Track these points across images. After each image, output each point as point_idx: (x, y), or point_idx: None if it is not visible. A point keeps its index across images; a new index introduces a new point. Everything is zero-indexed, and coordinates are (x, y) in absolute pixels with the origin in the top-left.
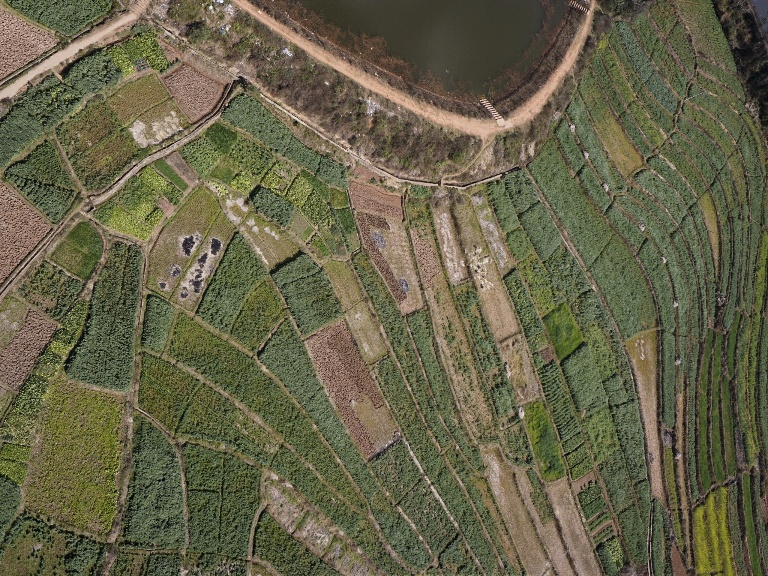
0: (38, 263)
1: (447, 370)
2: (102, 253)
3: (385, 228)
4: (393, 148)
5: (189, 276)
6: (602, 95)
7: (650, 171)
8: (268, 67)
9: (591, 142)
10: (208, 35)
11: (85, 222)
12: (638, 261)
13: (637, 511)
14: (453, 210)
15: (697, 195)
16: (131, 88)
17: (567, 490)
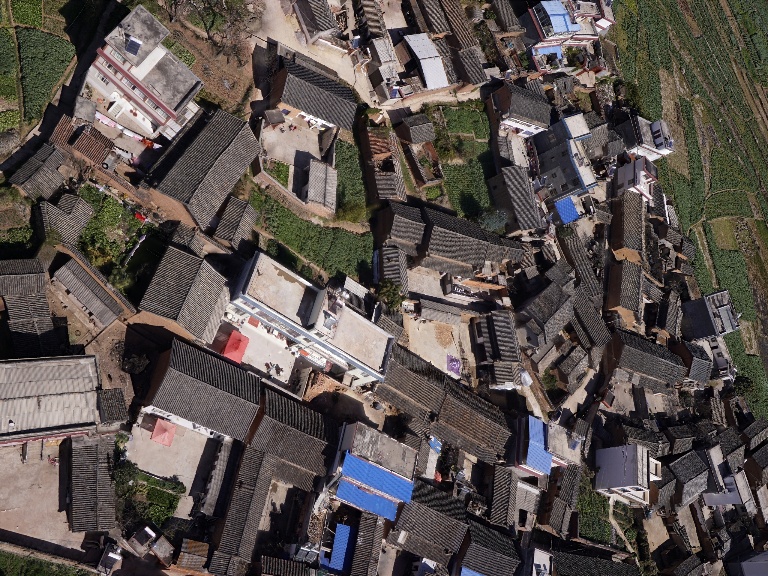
0: None
1: (712, 17)
2: None
3: None
4: None
5: None
6: None
7: None
8: None
9: None
10: None
11: None
12: None
13: None
14: None
15: None
16: None
17: (761, 91)
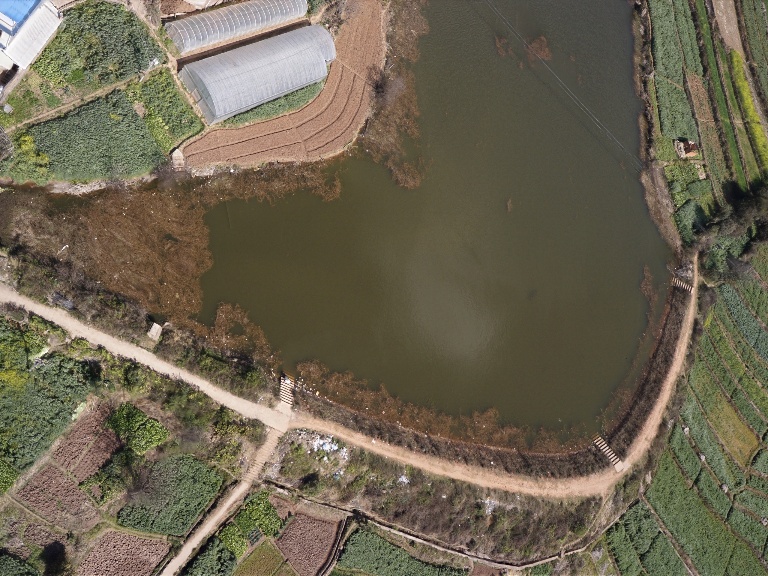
0: None
1: None
2: None
3: None
4: (513, 543)
5: None
6: (712, 378)
7: (767, 449)
8: (384, 499)
9: (706, 441)
10: (323, 488)
11: None
12: (764, 563)
13: None
14: None
15: None
16: (245, 567)
17: None
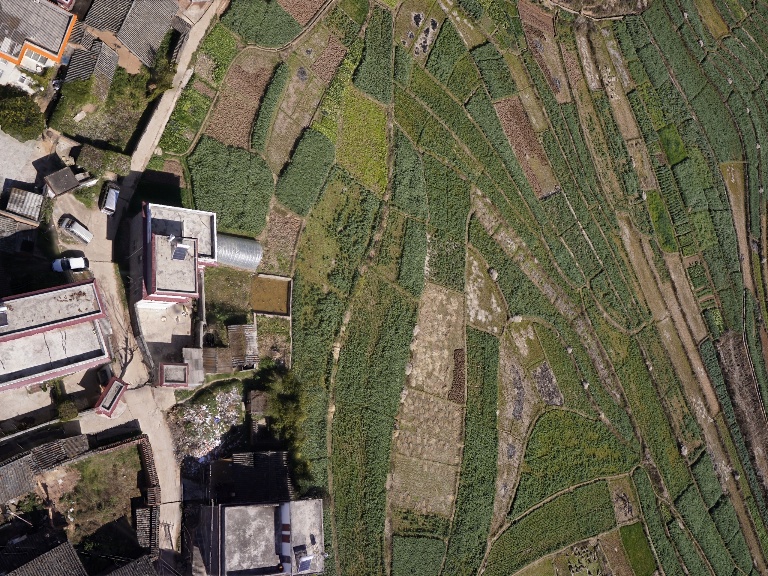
0: (334, 6)
1: (590, 150)
2: (369, 10)
3: (543, 38)
4: None
5: (419, 40)
6: None
7: (735, 39)
8: None
9: (689, 6)
10: None
11: None
12: (727, 107)
13: (733, 293)
14: (589, 36)
15: None
16: None
17: (679, 263)
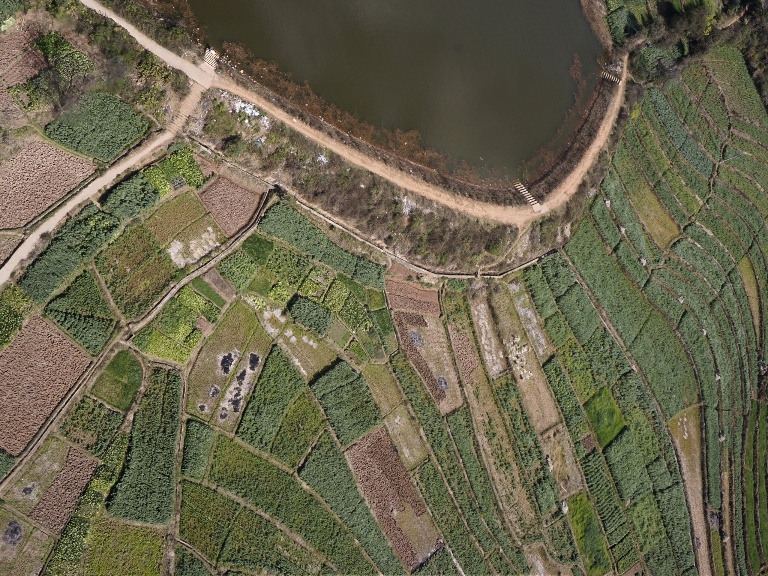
0: (78, 399)
1: (488, 469)
2: (142, 381)
3: (422, 325)
4: (429, 245)
5: (228, 395)
6: (636, 166)
7: (687, 240)
8: (304, 175)
9: (627, 216)
10: (244, 149)
11: (124, 351)
12: (678, 335)
13: None
14: (490, 300)
15: (735, 260)
16: (168, 207)
17: None
